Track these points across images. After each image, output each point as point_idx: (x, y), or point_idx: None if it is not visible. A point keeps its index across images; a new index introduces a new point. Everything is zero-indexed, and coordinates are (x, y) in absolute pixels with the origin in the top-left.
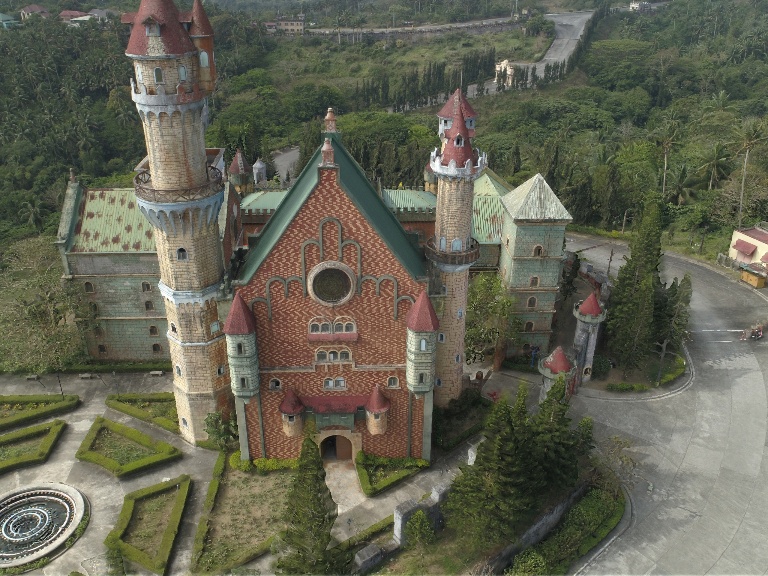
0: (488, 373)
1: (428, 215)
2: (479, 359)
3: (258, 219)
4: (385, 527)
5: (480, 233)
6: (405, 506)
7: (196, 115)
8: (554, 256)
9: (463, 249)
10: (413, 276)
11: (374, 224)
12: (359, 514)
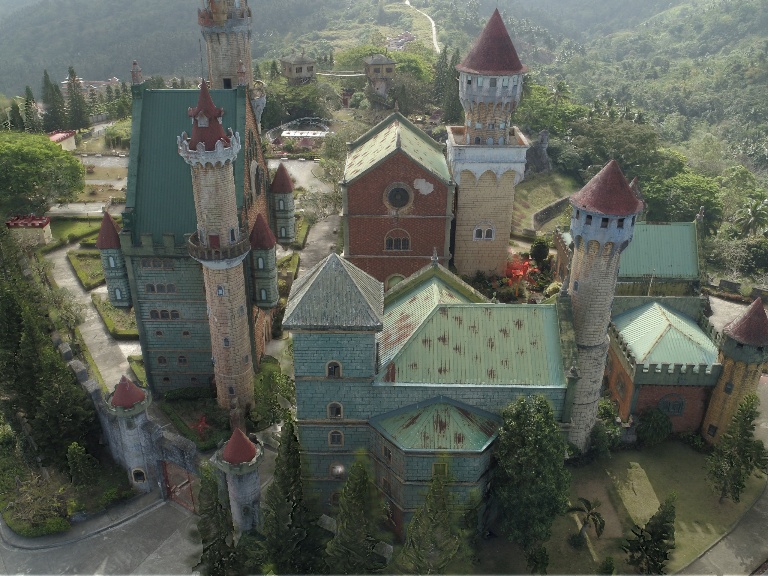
0: None
1: (626, 360)
2: None
3: None
4: (89, 366)
5: (384, 319)
6: (64, 346)
7: (215, 38)
8: None
9: None
10: (127, 204)
11: (136, 146)
12: (117, 360)
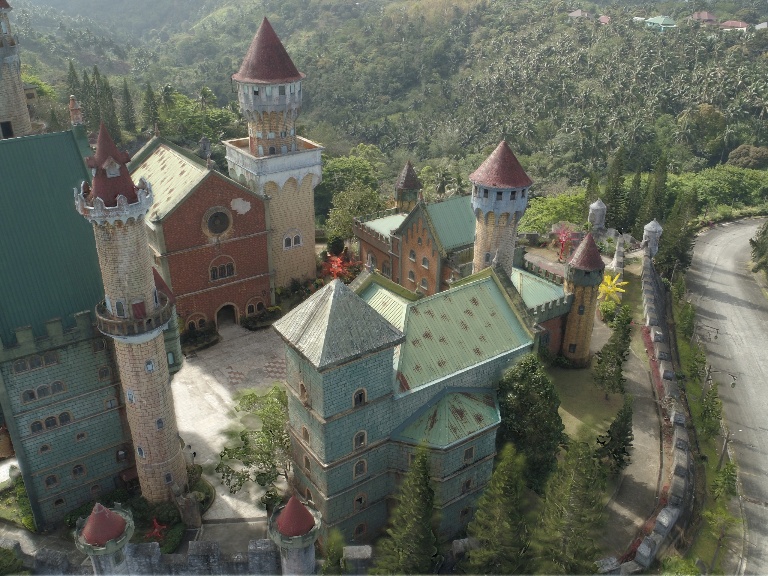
0: (261, 517)
1: None
2: (231, 486)
3: (367, 238)
4: None
5: None
6: None
7: None
8: (317, 412)
9: (116, 313)
10: None
11: None
12: None
